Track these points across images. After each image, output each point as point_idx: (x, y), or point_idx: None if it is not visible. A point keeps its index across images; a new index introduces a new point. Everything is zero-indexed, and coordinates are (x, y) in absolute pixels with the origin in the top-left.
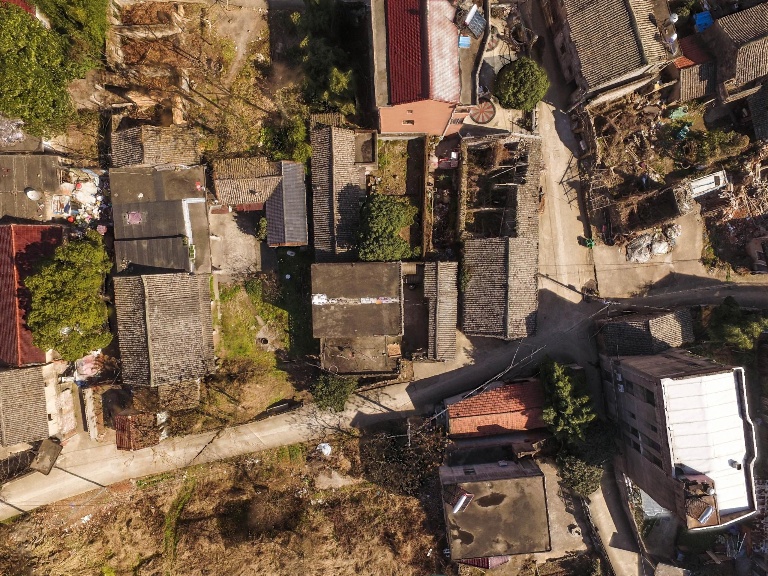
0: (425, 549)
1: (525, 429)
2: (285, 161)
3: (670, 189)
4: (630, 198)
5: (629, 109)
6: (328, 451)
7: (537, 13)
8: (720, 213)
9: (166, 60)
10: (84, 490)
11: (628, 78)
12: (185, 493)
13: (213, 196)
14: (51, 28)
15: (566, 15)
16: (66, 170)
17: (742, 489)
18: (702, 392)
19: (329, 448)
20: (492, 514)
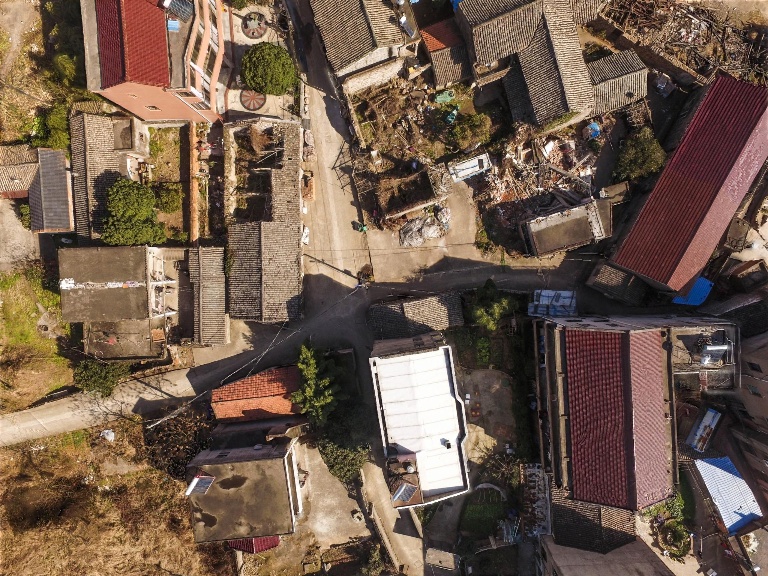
0: None
1: (292, 413)
2: (42, 148)
3: (422, 172)
4: (381, 181)
5: (394, 94)
6: (112, 437)
7: (305, 0)
8: (489, 196)
9: None
10: None
11: (375, 62)
12: None
13: None
14: None
15: None
16: None
17: (456, 468)
18: (411, 371)
19: (112, 434)
20: (234, 496)
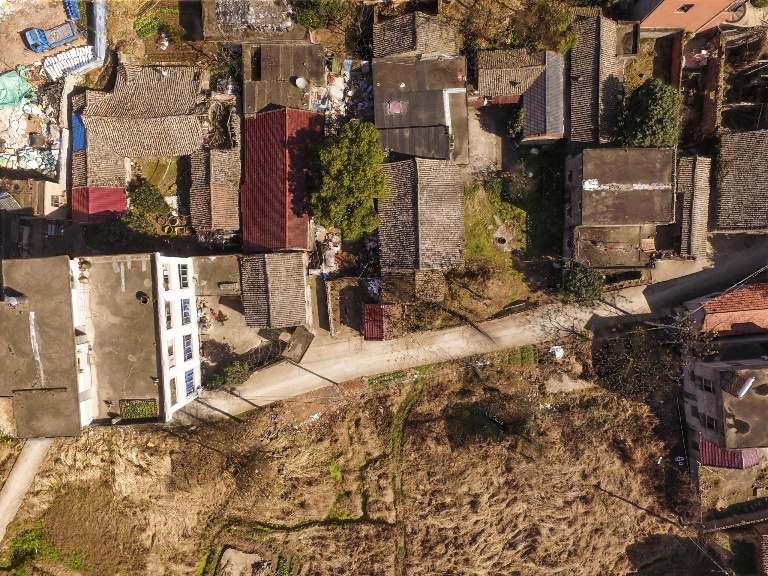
0: (655, 457)
1: None
2: (549, 51)
3: None
4: None
5: None
6: (561, 354)
7: None
8: None
9: None
10: (317, 387)
11: None
12: (414, 394)
13: (472, 87)
14: None
15: None
16: (327, 61)
17: None
18: None
19: (562, 351)
20: None
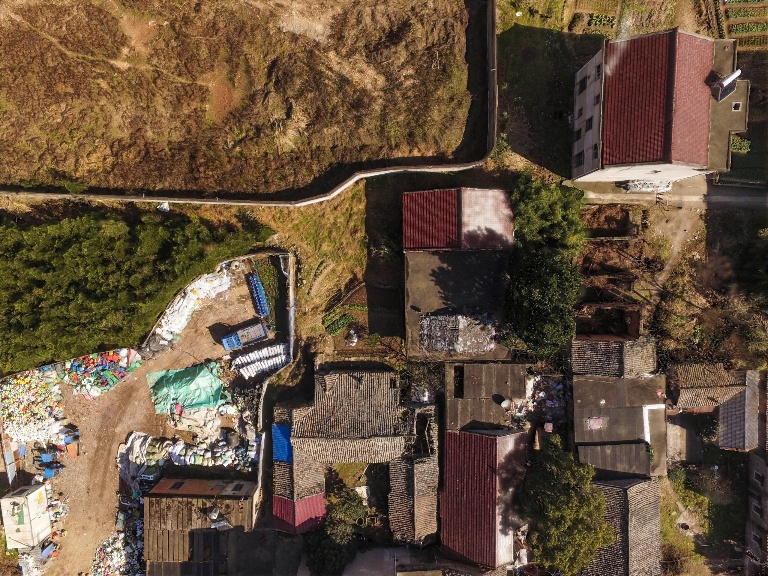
0: None
1: None
2: (748, 371)
3: None
4: None
5: None
6: None
7: None
8: None
9: (610, 262)
10: None
11: None
12: None
13: (670, 401)
14: None
15: None
16: None
17: None
18: None
19: None
20: None
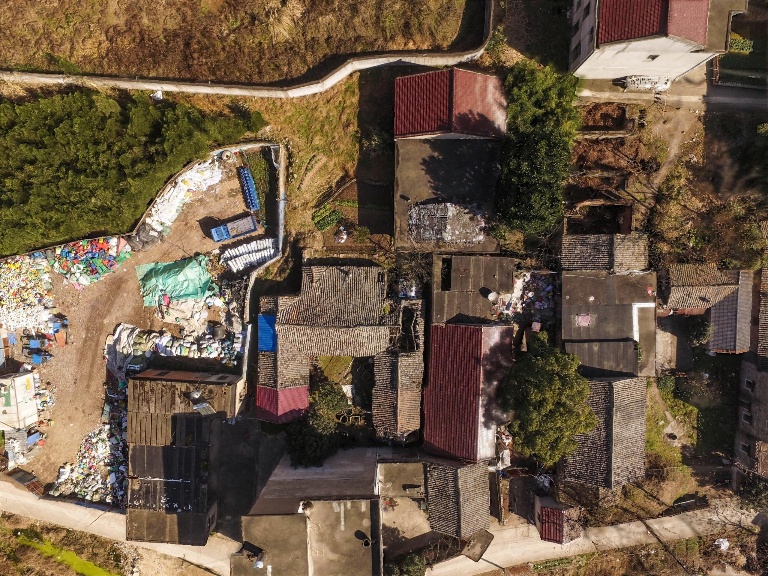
0: None
1: None
2: (742, 270)
3: None
4: None
5: None
6: (726, 546)
7: None
8: None
9: (605, 161)
10: (483, 571)
11: None
12: None
13: (660, 301)
14: None
15: None
16: (515, 270)
17: None
18: None
19: (727, 544)
20: None
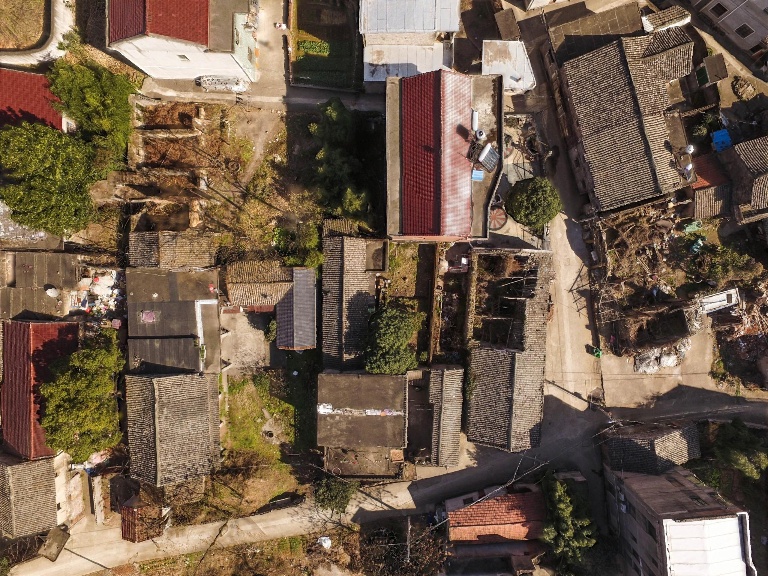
0: None
1: (525, 539)
2: (297, 267)
3: (680, 310)
4: (639, 318)
5: (642, 223)
6: (328, 545)
7: (552, 123)
8: (731, 329)
9: (185, 160)
10: (89, 571)
11: None
12: None
13: (225, 297)
14: (76, 127)
15: (581, 136)
16: (85, 267)
17: None
18: (705, 535)
19: (329, 542)
20: None
